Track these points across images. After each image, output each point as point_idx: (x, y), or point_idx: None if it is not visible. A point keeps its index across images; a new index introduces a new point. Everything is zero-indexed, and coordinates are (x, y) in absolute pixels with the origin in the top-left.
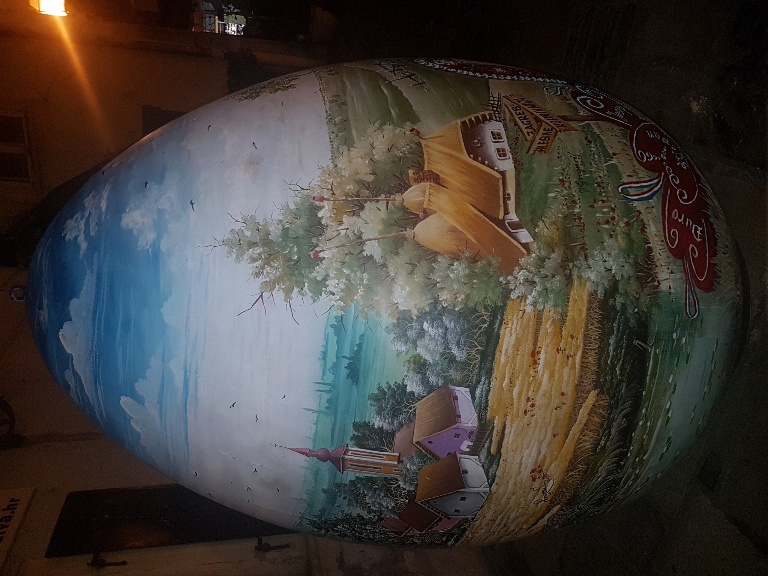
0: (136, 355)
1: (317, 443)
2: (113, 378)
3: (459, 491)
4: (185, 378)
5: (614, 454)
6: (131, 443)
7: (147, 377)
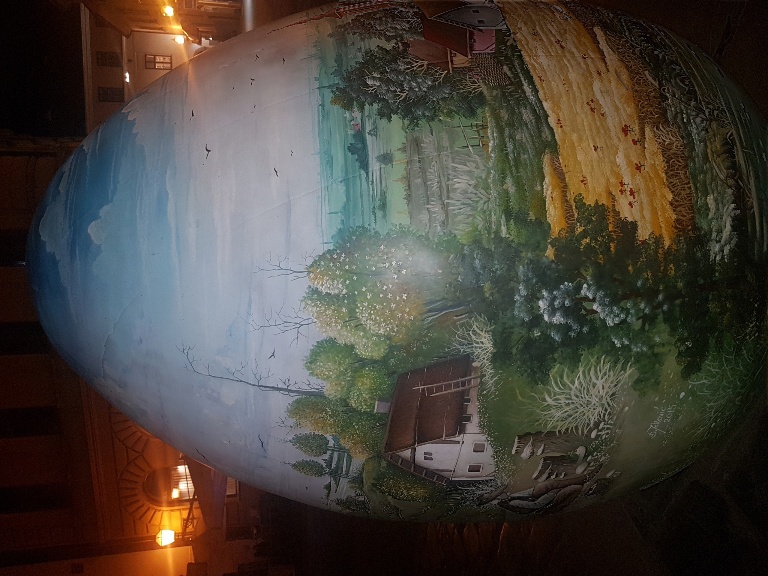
0: None
1: None
2: None
3: None
4: None
5: (600, 6)
6: (120, 151)
7: (155, 80)
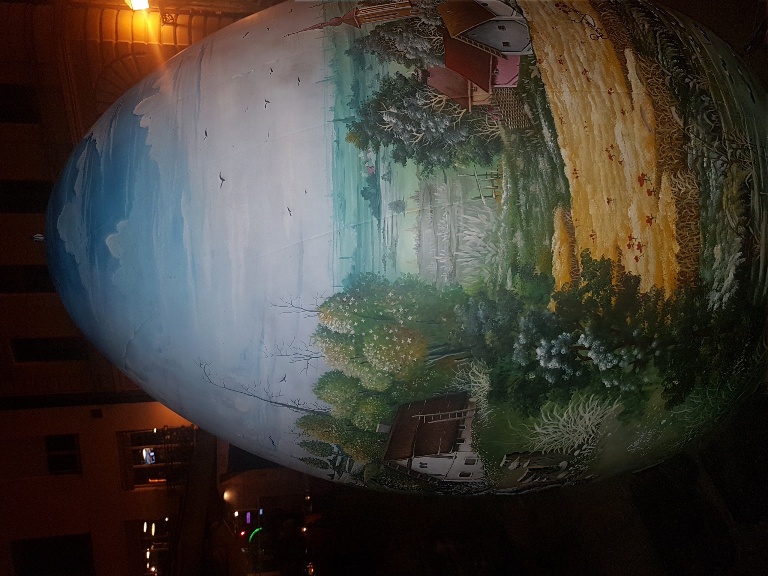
0: (158, 75)
1: (328, 17)
2: (131, 101)
3: (491, 20)
4: (202, 50)
5: None
6: (134, 164)
7: (166, 73)
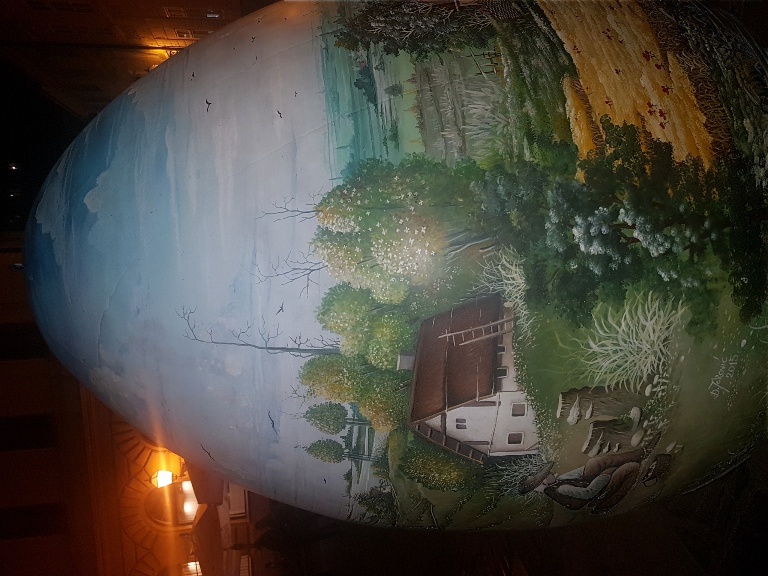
0: None
1: None
2: None
3: None
4: None
5: None
6: None
7: None
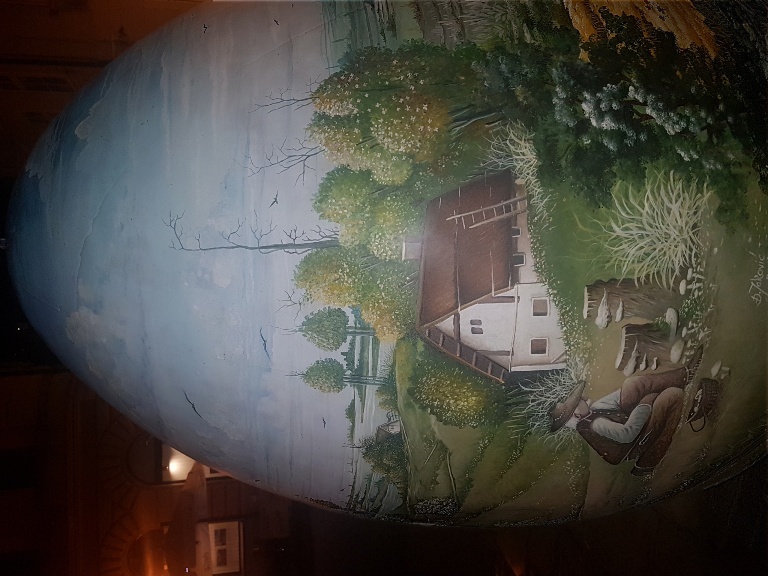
0: None
1: None
2: None
3: None
4: None
5: None
6: None
7: None
